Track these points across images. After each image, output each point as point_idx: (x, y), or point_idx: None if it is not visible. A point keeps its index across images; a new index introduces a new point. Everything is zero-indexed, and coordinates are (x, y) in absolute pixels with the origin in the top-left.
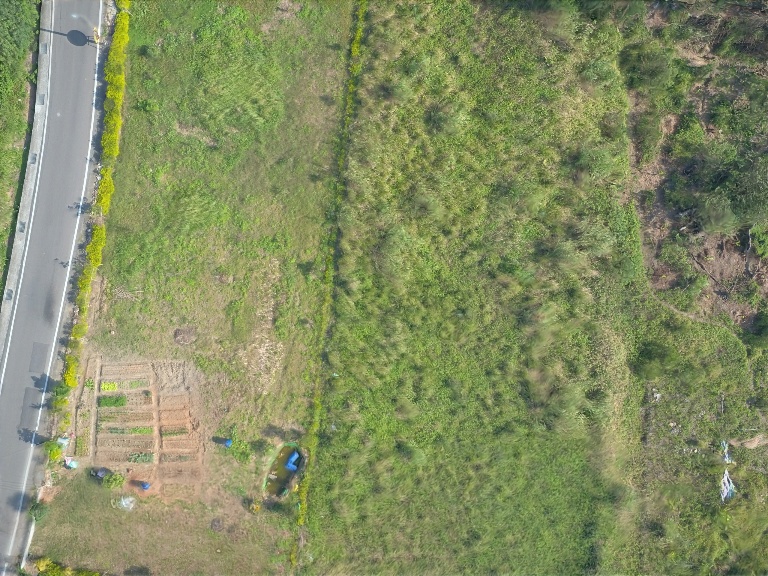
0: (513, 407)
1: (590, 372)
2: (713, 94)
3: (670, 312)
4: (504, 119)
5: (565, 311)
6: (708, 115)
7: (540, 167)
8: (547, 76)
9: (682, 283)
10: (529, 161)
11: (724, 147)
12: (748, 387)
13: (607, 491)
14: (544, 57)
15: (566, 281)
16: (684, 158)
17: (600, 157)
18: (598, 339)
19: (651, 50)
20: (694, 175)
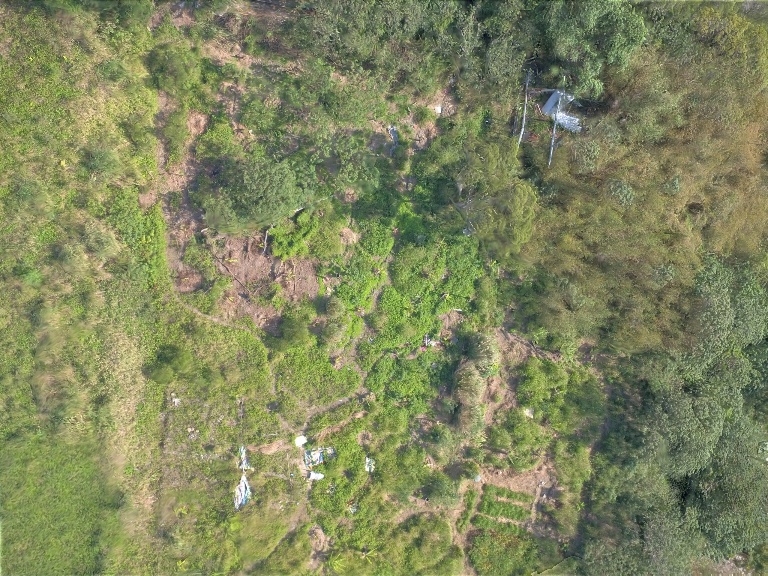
0: (23, 412)
1: (99, 376)
2: (244, 94)
3: (191, 315)
4: (20, 120)
5: (78, 314)
6: (238, 115)
7: (58, 168)
8: (68, 76)
9: (204, 285)
10: (47, 162)
11: (251, 147)
12: (268, 391)
13: (102, 498)
14: (63, 57)
15: (81, 284)
16: (210, 159)
17: (99, 158)
18: (109, 343)
19: (178, 49)
20: (219, 176)
